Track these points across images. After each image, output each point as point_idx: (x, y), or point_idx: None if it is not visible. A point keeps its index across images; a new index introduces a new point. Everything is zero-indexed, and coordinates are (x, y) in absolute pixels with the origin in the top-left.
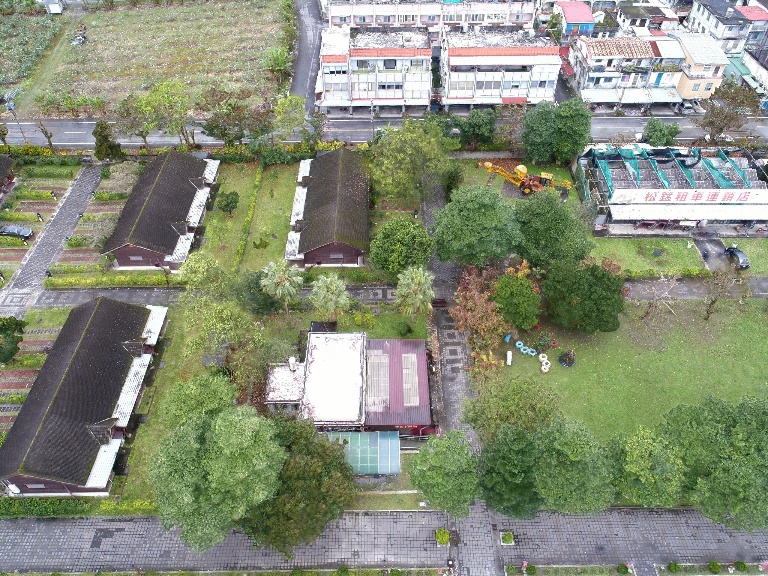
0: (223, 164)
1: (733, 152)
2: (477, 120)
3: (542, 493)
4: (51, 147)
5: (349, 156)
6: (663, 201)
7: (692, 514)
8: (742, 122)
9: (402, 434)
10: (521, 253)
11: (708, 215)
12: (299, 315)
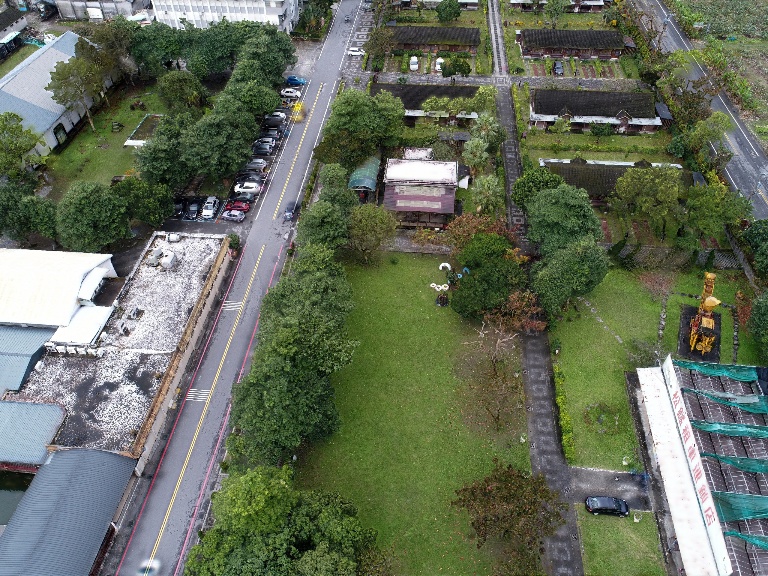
0: (671, 135)
1: None
2: (765, 244)
3: None
4: None
5: (682, 179)
6: None
7: None
8: None
9: None
10: None
11: (670, 474)
12: None
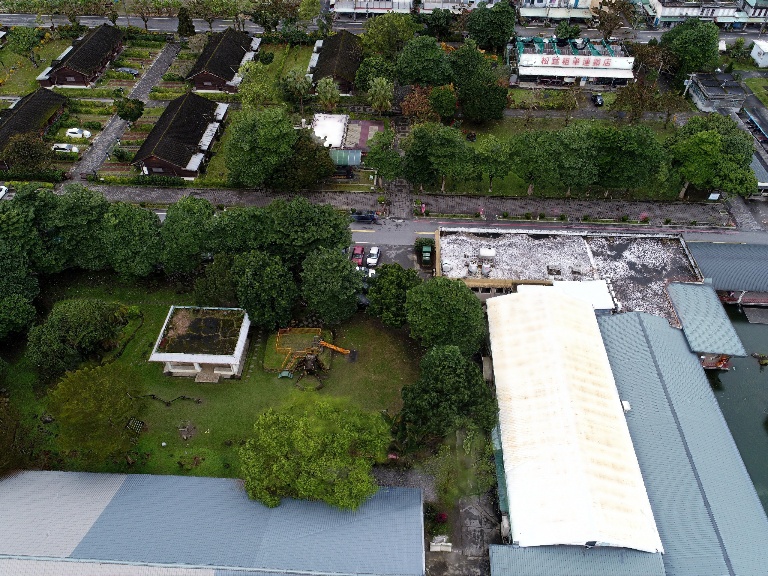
0: (263, 44)
1: (612, 42)
2: (437, 14)
3: None
4: (146, 29)
5: (349, 35)
6: (554, 65)
7: (525, 200)
8: (618, 21)
9: None
10: None
11: (583, 74)
12: (309, 116)
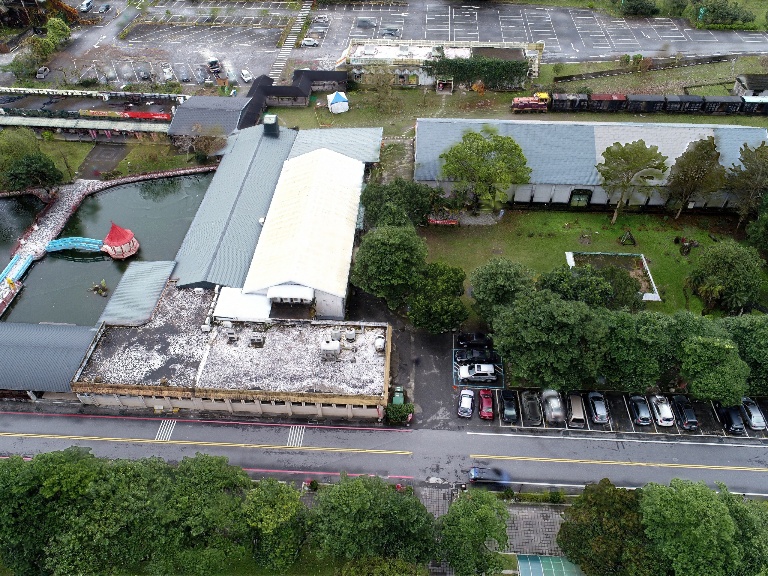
0: None
1: None
2: None
3: None
4: None
5: None
6: None
7: None
8: None
9: None
10: None
11: None
12: None
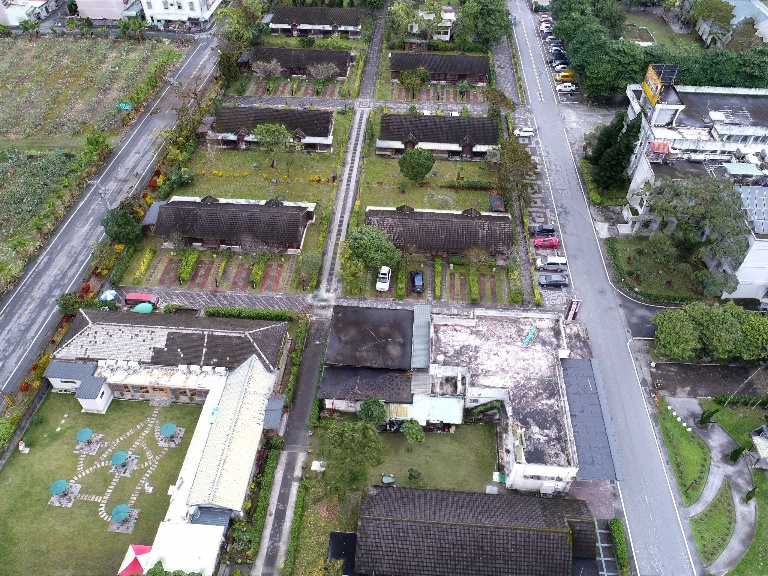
0: None
1: None
2: None
3: None
4: None
5: None
6: None
7: None
8: None
9: None
10: None
11: None
12: None
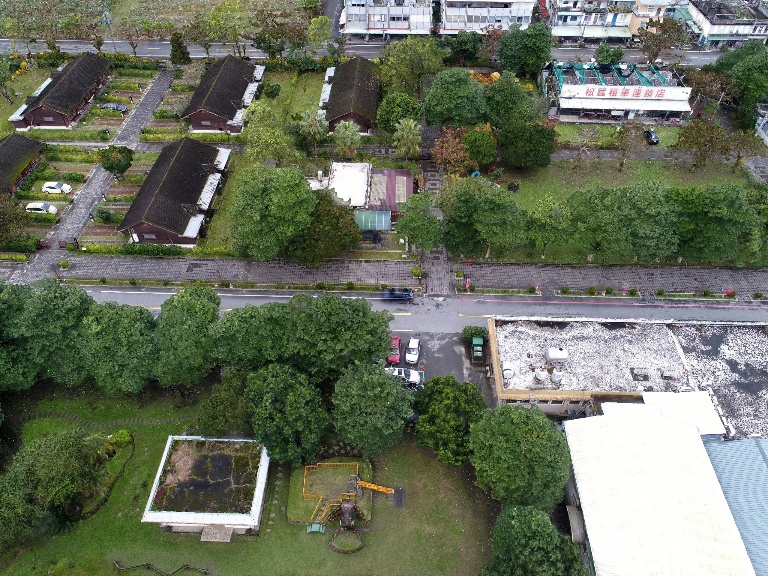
0: (267, 71)
1: (661, 67)
2: (463, 38)
3: (478, 228)
4: (135, 55)
5: (364, 63)
6: (600, 96)
7: (585, 268)
8: (668, 44)
9: (393, 221)
10: (487, 121)
11: (633, 107)
12: (324, 161)
